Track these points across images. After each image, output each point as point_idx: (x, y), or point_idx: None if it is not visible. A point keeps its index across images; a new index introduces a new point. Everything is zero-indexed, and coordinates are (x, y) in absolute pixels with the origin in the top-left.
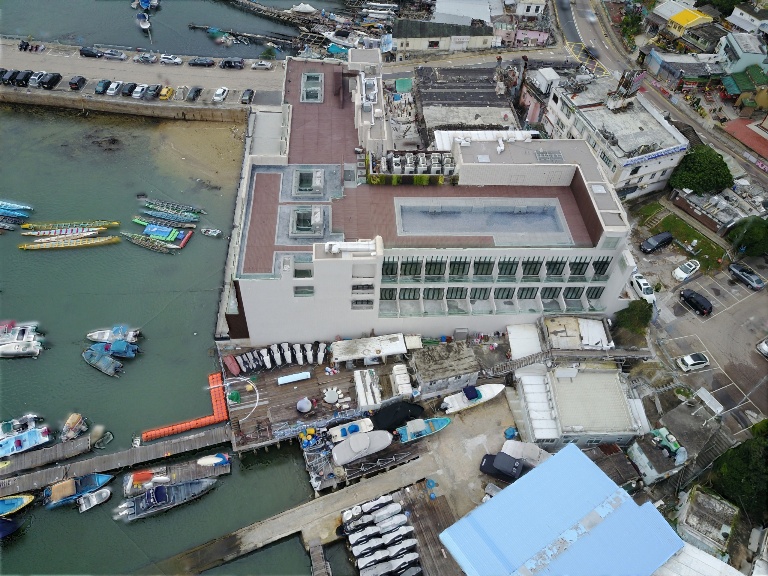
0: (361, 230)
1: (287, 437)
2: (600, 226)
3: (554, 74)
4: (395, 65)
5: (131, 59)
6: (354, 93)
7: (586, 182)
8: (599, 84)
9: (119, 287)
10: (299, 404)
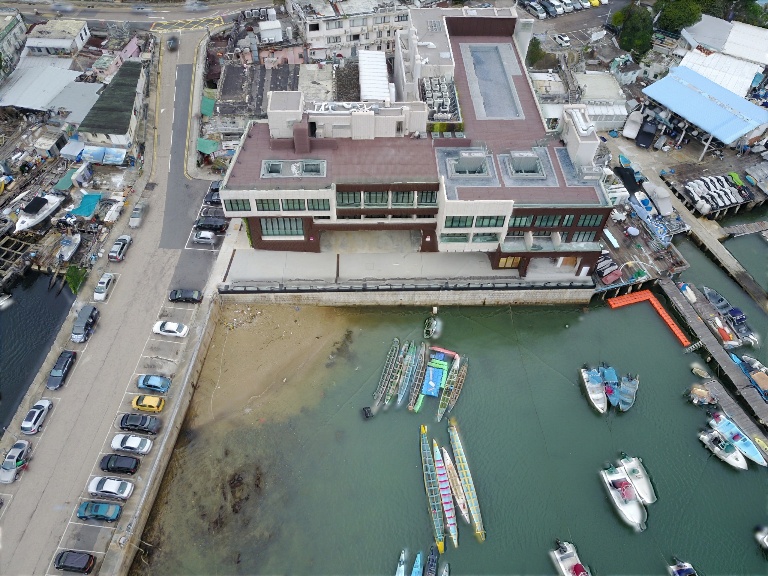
0: (525, 138)
1: (661, 242)
2: (510, 19)
3: (272, 22)
4: (152, 154)
5: (1, 490)
6: (322, 131)
7: (464, 16)
8: (300, 1)
9: (524, 405)
10: (634, 234)
